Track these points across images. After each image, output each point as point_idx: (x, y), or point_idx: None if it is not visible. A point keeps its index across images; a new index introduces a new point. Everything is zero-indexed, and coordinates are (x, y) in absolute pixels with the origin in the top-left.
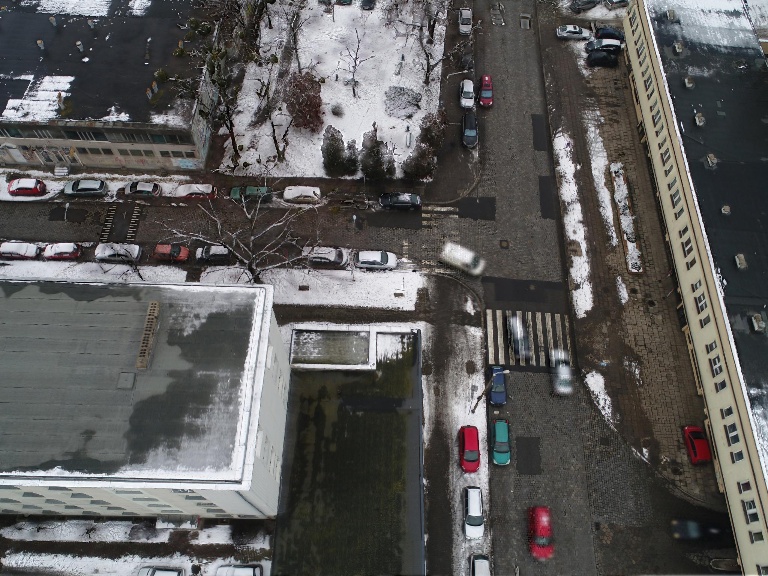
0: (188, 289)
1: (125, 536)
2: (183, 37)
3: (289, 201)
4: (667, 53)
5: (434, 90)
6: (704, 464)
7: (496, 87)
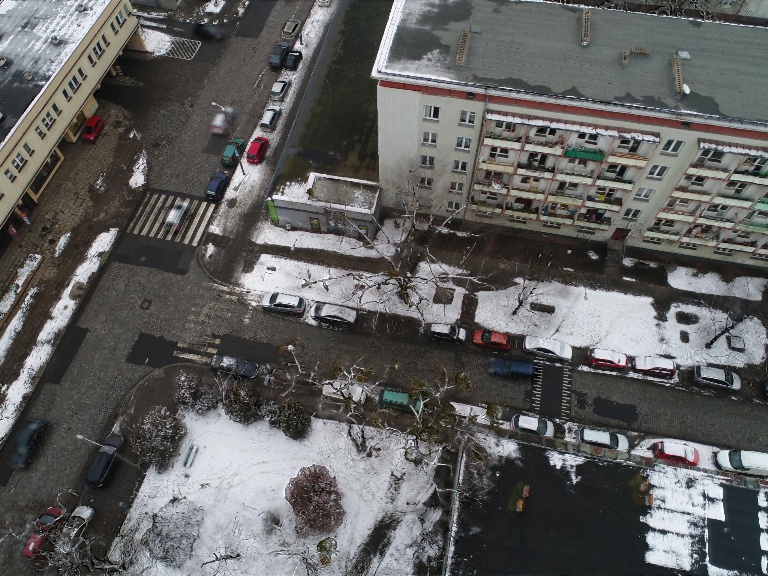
0: (437, 77)
1: None
2: None
3: None
4: None
5: (118, 553)
6: None
7: None
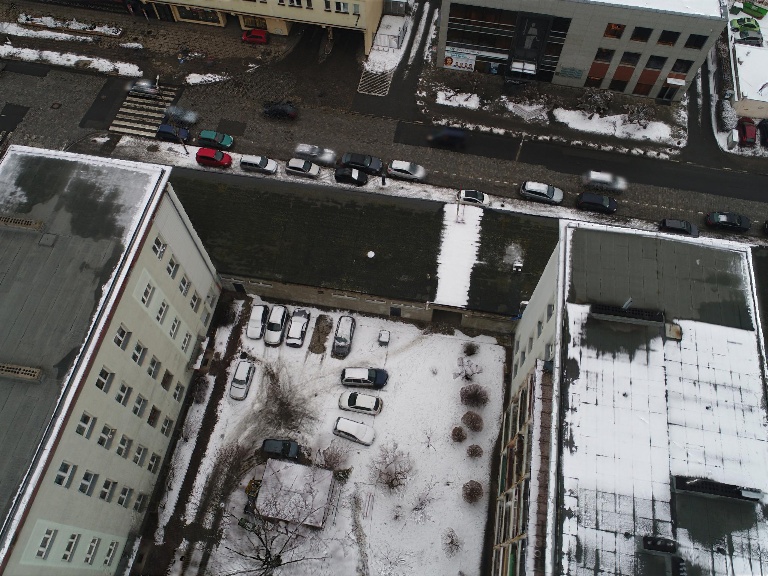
0: None
1: (200, 411)
2: None
3: None
4: None
5: None
6: (269, 38)
7: None
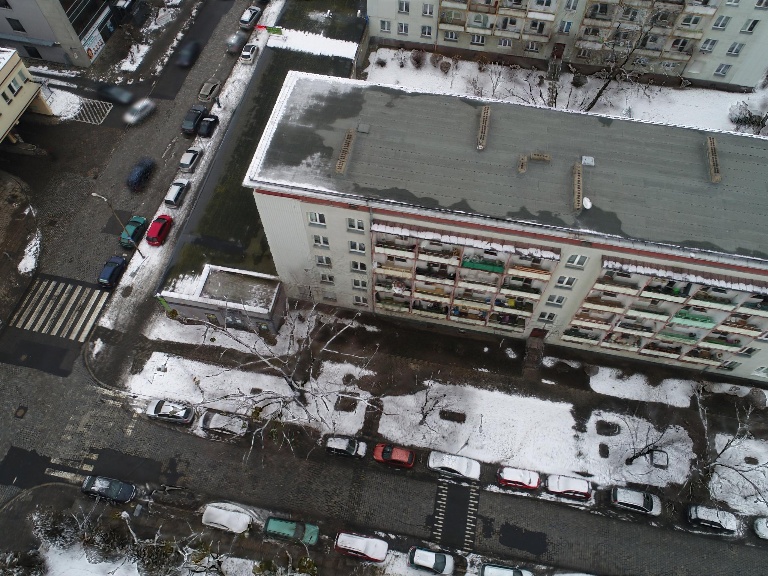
0: (314, 187)
1: None
2: None
3: None
4: None
5: None
6: None
7: None
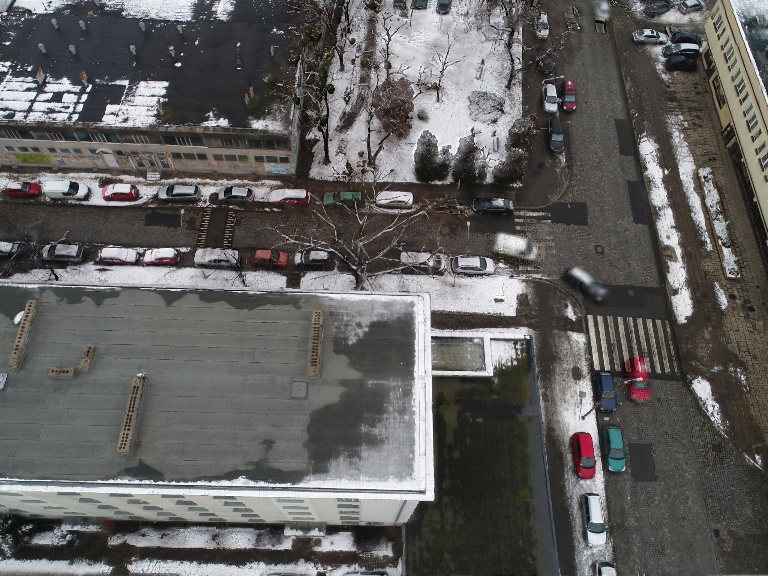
0: (346, 297)
1: (249, 543)
2: (272, 42)
3: (382, 206)
4: (761, 58)
5: (516, 94)
6: None
7: (577, 91)
